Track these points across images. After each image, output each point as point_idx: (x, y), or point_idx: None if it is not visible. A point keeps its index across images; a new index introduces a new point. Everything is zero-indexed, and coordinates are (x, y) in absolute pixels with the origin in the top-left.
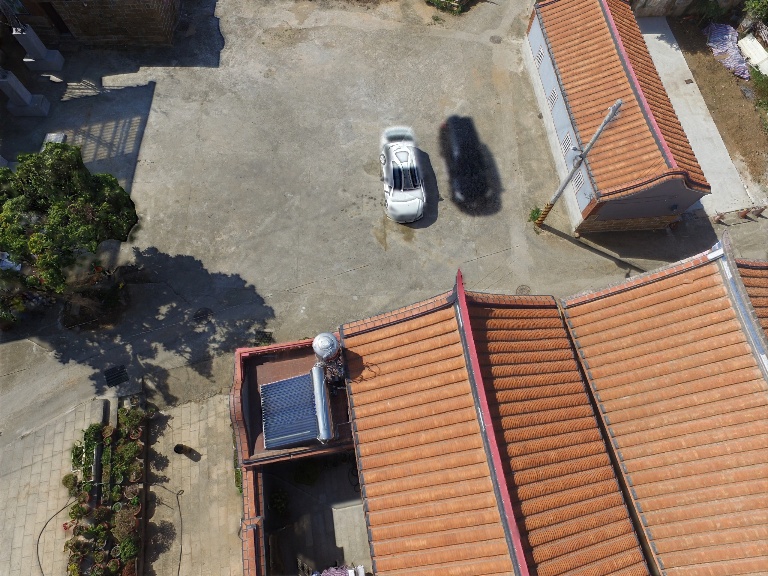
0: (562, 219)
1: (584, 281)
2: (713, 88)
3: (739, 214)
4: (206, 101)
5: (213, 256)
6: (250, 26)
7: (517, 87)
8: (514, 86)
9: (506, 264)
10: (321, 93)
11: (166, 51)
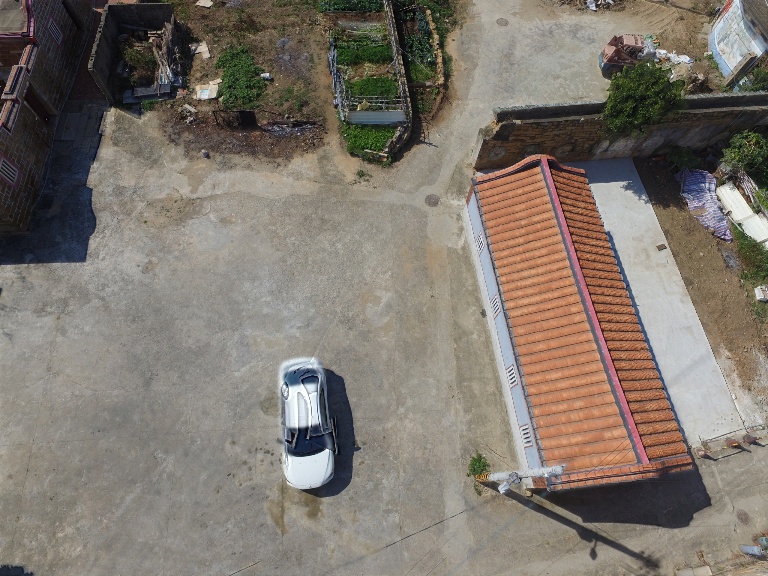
0: (510, 469)
1: (538, 565)
2: (690, 255)
3: (727, 442)
4: (64, 314)
5: (50, 564)
6: (130, 198)
7: (456, 271)
8: (453, 269)
9: (438, 546)
10: (213, 293)
11: (20, 241)
